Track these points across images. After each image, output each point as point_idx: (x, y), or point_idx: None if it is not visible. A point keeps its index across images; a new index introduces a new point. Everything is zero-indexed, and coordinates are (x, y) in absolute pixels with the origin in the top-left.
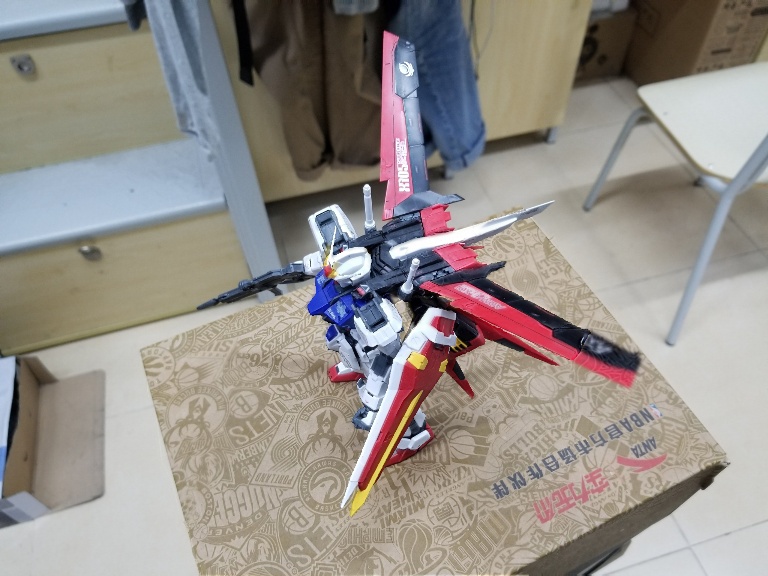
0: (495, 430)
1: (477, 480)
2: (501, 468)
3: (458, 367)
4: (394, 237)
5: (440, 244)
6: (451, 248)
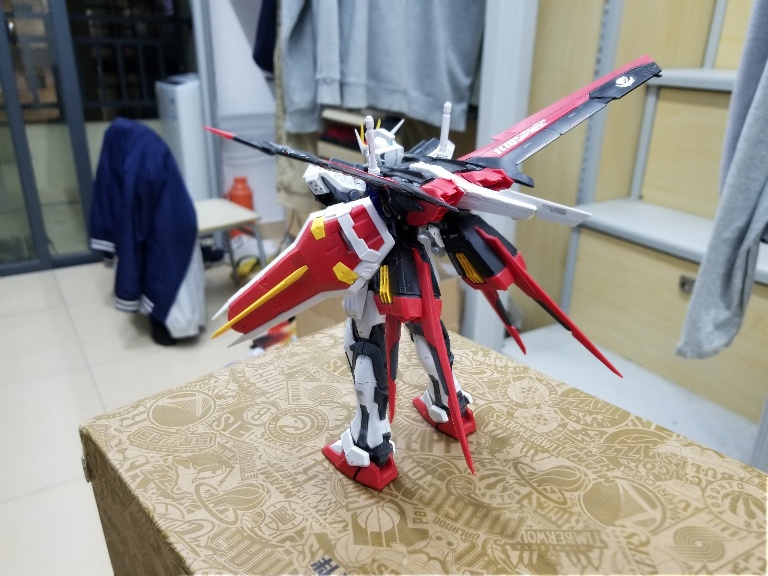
0: (413, 549)
1: (333, 540)
2: (357, 564)
3: (395, 354)
4: (435, 163)
5: (447, 178)
6: (447, 183)
